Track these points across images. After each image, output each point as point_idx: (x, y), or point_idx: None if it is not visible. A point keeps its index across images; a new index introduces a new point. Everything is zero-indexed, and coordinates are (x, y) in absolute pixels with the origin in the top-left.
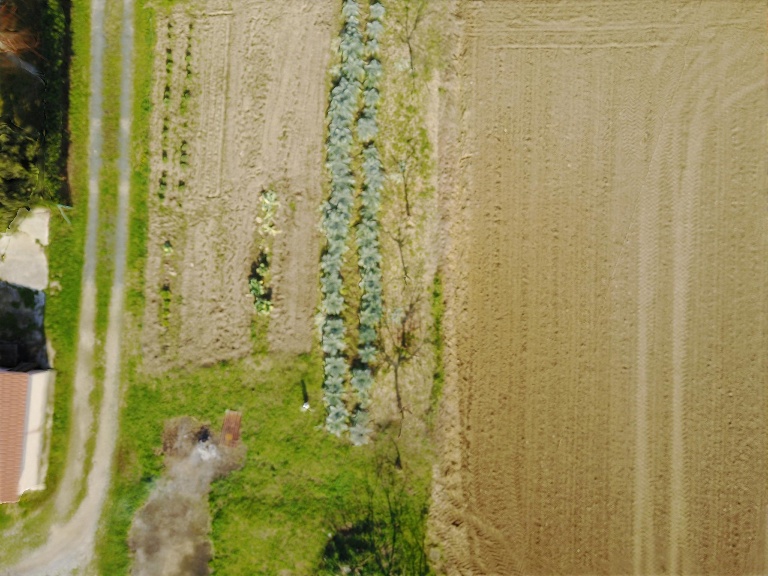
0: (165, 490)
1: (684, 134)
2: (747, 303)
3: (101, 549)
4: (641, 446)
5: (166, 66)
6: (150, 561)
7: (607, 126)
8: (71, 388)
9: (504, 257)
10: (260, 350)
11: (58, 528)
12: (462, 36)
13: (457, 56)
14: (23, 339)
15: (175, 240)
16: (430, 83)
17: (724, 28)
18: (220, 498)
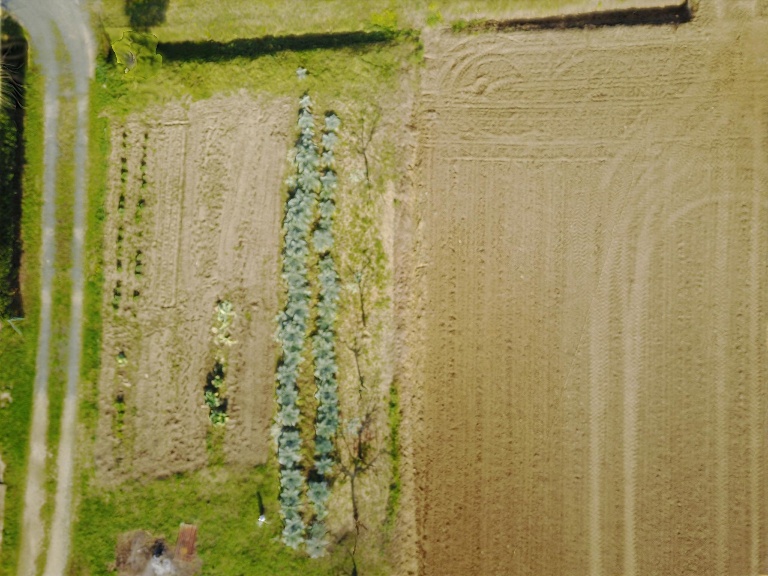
0: None
1: (632, 248)
2: (694, 413)
3: None
4: (593, 555)
5: (121, 176)
6: None
7: (559, 238)
8: (21, 503)
9: (459, 367)
10: (215, 462)
11: None
12: (417, 146)
13: (412, 166)
14: None
15: (129, 351)
16: (386, 194)
17: (670, 145)
18: None
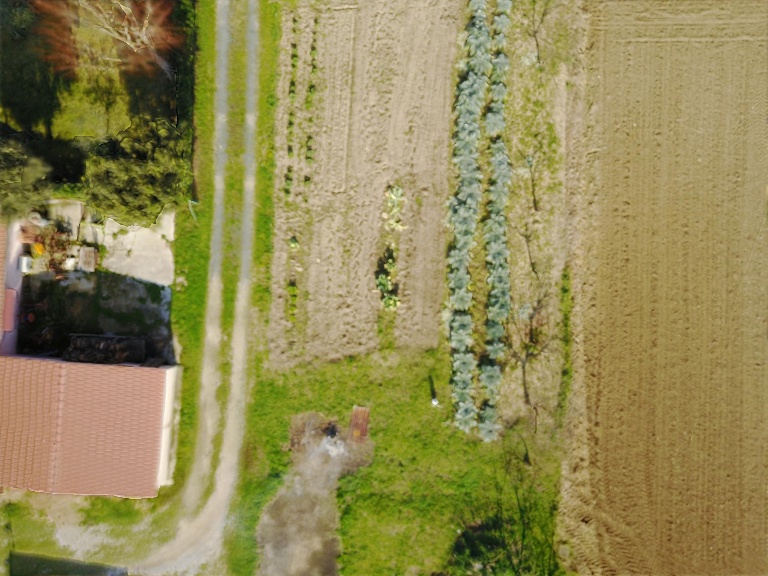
0: (293, 486)
1: None
2: None
3: (230, 544)
4: None
5: (291, 61)
6: (278, 556)
7: (739, 120)
8: (198, 384)
9: (633, 253)
10: (387, 346)
11: (186, 523)
12: (588, 30)
13: (583, 50)
14: (150, 335)
15: (301, 236)
16: (557, 77)
17: None
18: (348, 494)
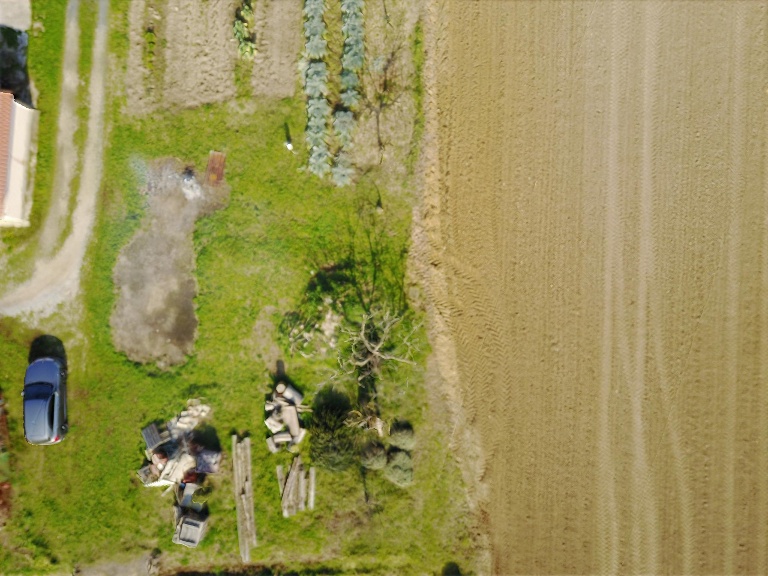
0: (149, 229)
1: None
2: (715, 49)
3: (86, 285)
4: (612, 186)
5: None
6: (135, 298)
7: None
8: (55, 128)
9: (484, 6)
10: (244, 94)
11: (42, 265)
12: None
13: None
14: (6, 79)
15: None
16: None
17: None
18: (204, 236)
